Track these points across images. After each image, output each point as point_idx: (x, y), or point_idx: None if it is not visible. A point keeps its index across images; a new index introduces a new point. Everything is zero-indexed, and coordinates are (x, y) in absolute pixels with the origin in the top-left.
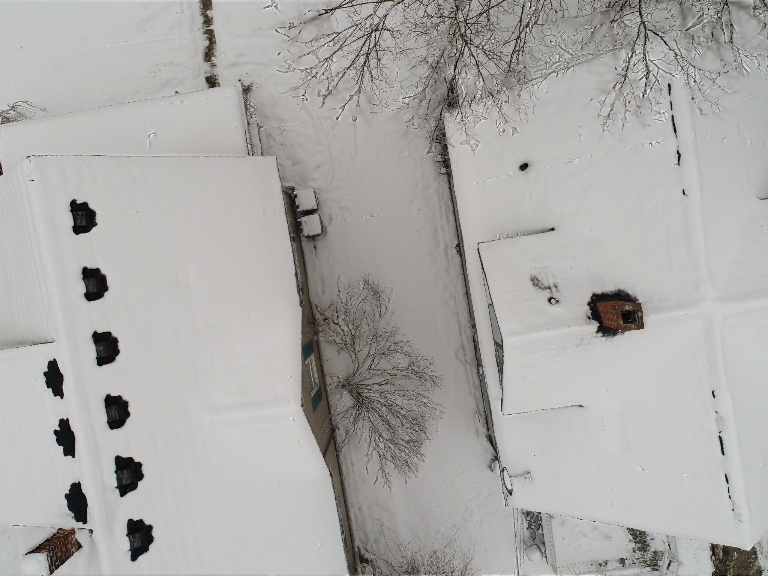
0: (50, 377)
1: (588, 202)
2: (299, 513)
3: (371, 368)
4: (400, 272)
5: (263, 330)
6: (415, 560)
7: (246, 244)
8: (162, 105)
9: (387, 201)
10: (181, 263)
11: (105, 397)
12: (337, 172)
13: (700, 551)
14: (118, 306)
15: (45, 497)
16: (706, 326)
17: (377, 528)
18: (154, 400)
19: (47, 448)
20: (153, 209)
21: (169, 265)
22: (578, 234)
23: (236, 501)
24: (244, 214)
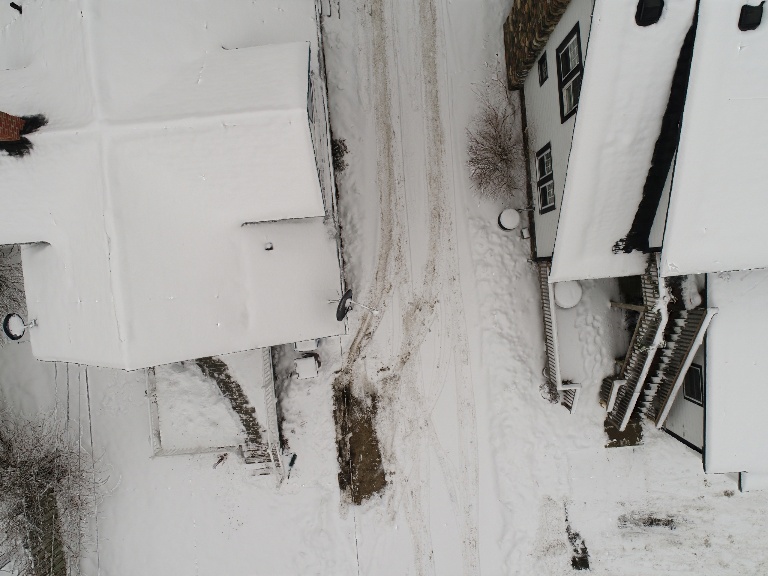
0: None
1: (44, 36)
2: None
3: None
4: None
5: None
6: None
7: None
8: None
9: None
10: None
11: None
12: None
13: (326, 451)
14: None
15: None
16: (99, 148)
17: (17, 410)
18: None
19: None
20: None
21: None
22: (39, 69)
23: None
24: None
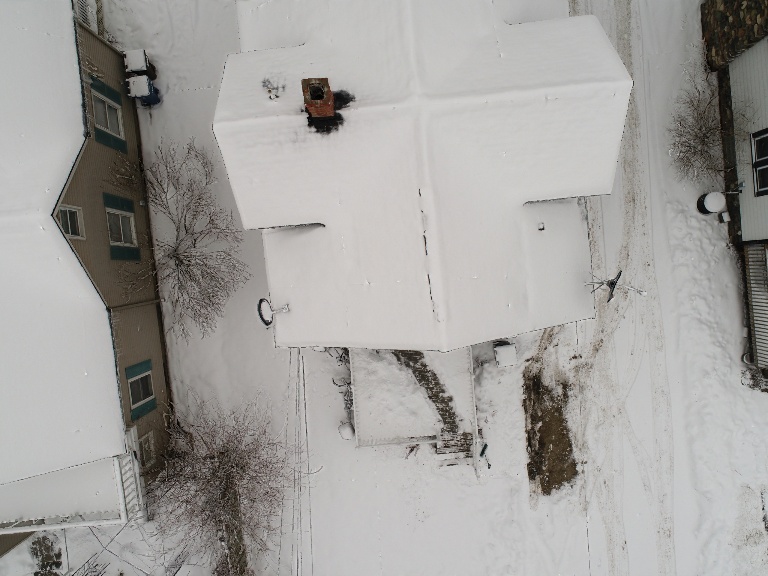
0: None
1: (330, 12)
2: (64, 338)
3: (189, 232)
4: None
5: (35, 150)
6: None
7: (23, 62)
8: None
9: None
10: None
11: None
12: (177, 41)
13: (516, 441)
14: None
15: None
16: (415, 123)
17: None
18: None
19: None
20: None
21: None
22: (321, 46)
23: None
24: (23, 33)
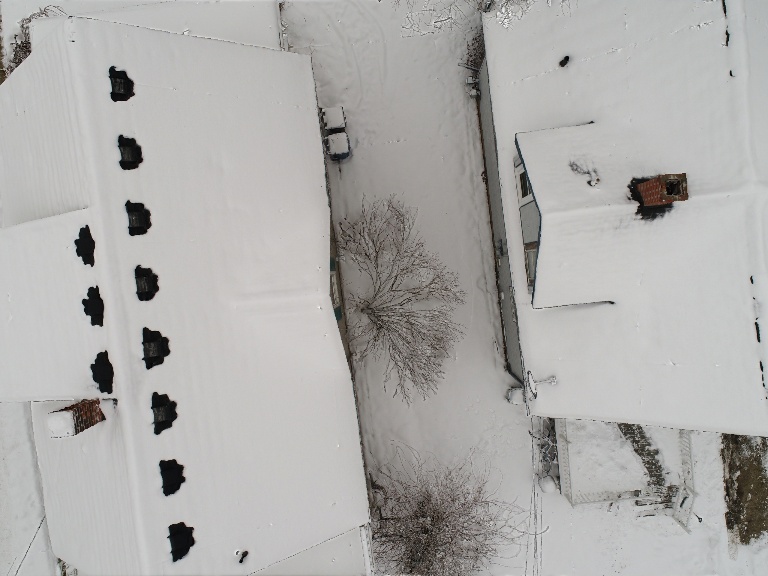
0: (81, 244)
1: (630, 92)
2: (320, 412)
3: (392, 289)
4: (424, 198)
5: (292, 224)
6: (429, 481)
7: (279, 137)
8: (197, 4)
9: (414, 126)
10: (215, 146)
11: (135, 267)
12: (365, 95)
13: (714, 491)
14: (152, 179)
15: (70, 368)
16: (747, 210)
17: (390, 455)
18: (183, 278)
19: (75, 318)
20: (190, 88)
21: (203, 146)
22: (618, 125)
23: (259, 390)
24: (278, 107)
